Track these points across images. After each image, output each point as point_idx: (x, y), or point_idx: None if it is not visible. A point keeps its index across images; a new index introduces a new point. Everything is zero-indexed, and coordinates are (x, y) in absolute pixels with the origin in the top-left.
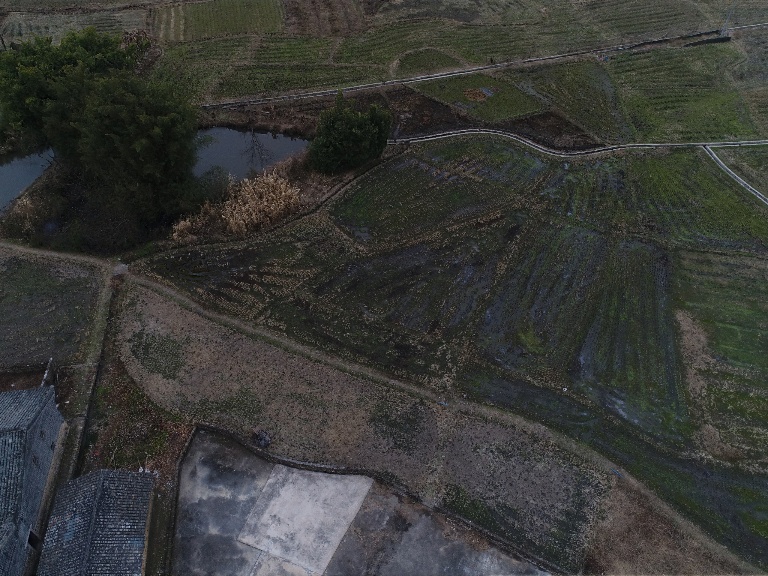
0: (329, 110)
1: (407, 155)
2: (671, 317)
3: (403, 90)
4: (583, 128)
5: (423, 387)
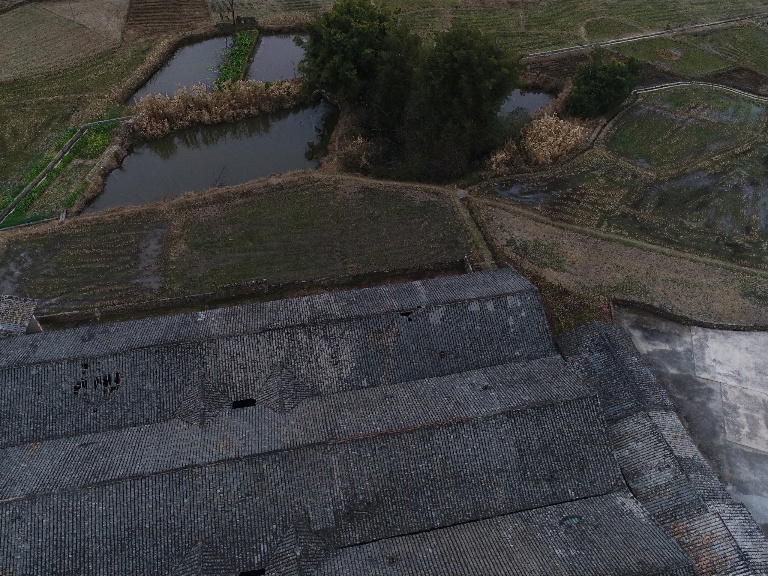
0: (585, 62)
1: (641, 103)
2: None
3: (603, 52)
4: None
5: None
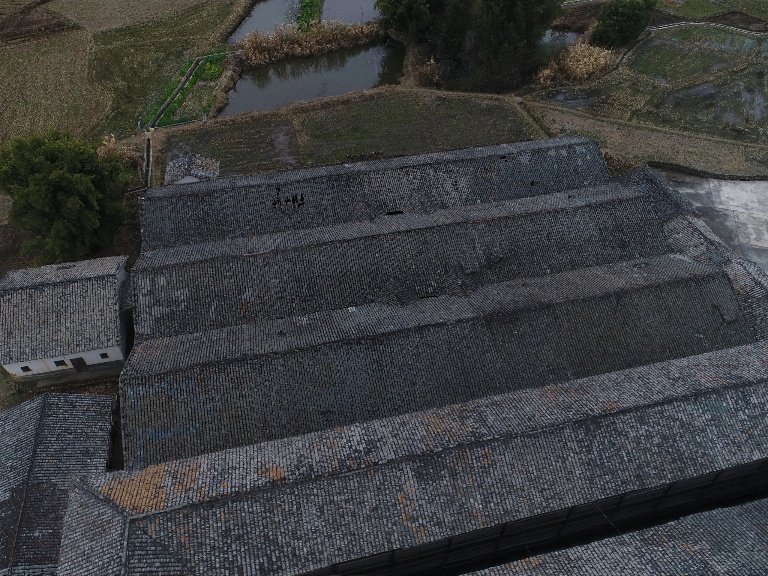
0: (608, 2)
1: (654, 37)
2: None
3: None
4: (765, 19)
5: (766, 145)
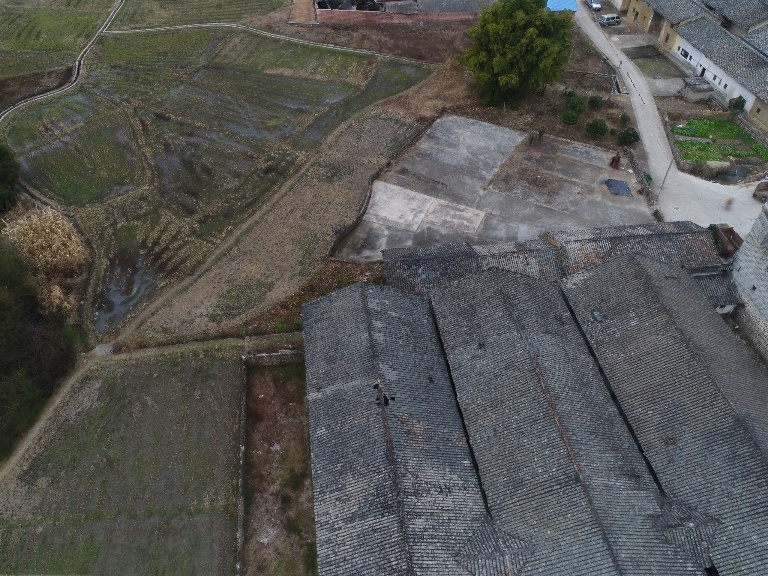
0: None
1: None
2: (268, 75)
3: None
4: (38, 71)
5: None
